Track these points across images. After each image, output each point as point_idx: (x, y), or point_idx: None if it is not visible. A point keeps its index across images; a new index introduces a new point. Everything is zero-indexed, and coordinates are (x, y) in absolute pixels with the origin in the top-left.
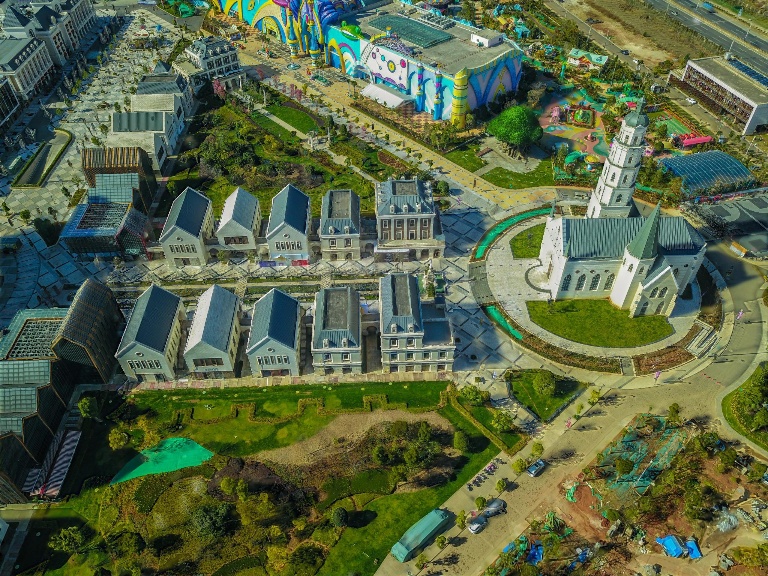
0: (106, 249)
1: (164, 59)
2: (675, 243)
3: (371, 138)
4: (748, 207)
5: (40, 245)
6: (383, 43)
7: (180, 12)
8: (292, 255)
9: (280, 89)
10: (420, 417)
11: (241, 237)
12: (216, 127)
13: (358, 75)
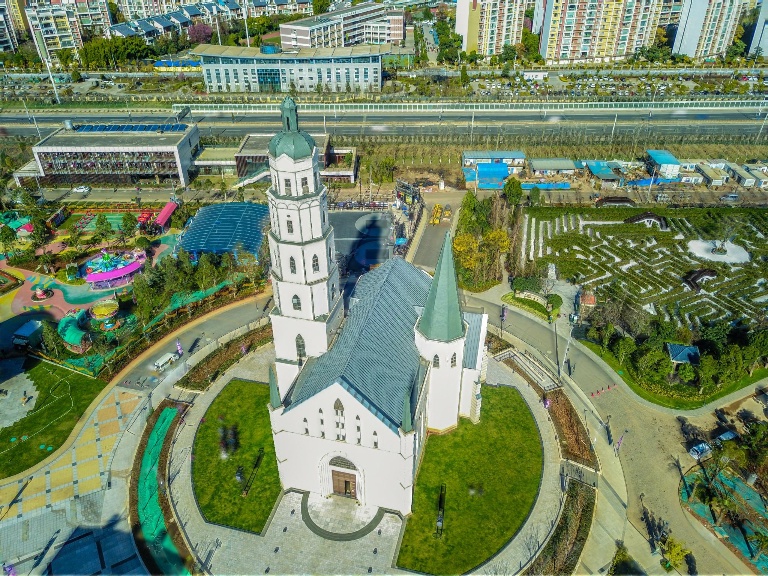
0: None
1: None
2: (424, 291)
3: None
4: None
5: None
6: None
7: None
8: None
9: None
10: None
11: None
12: None
13: None
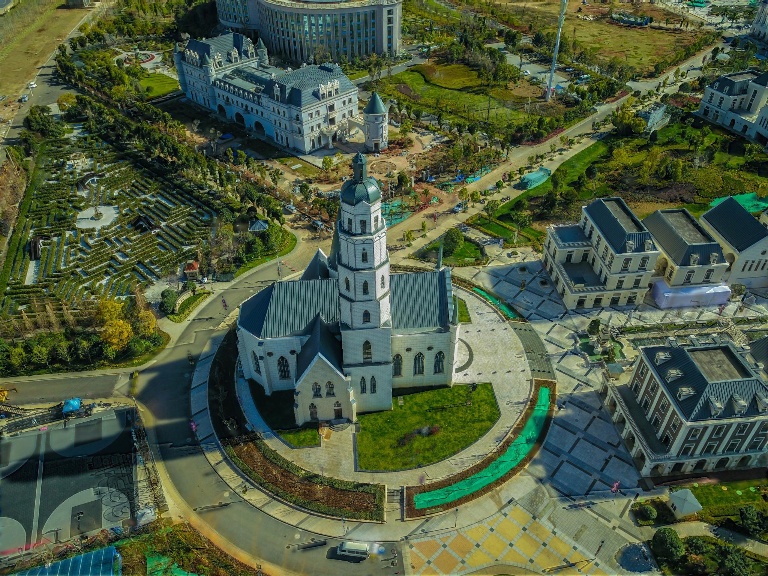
0: None
1: None
2: None
3: None
4: (18, 533)
5: None
6: None
7: None
8: None
9: None
10: None
11: None
12: None
13: None
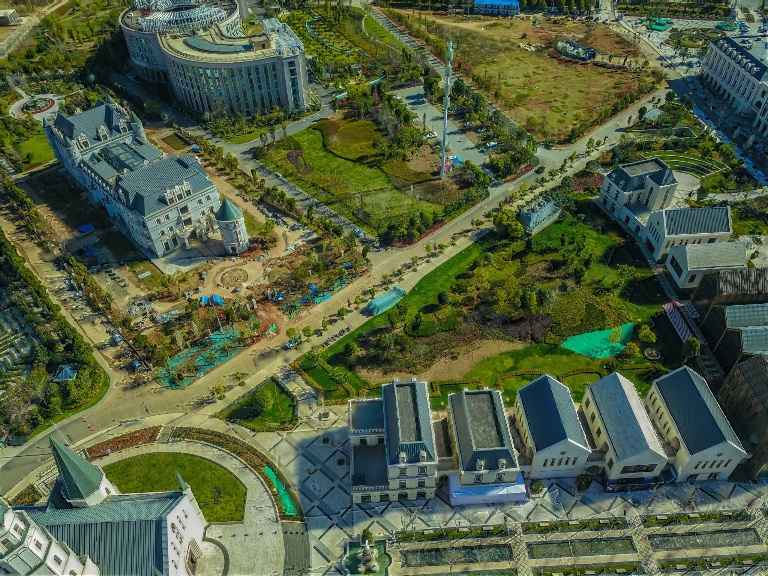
0: None
1: None
2: None
3: None
4: None
5: None
6: None
7: None
8: None
9: None
10: (386, 379)
11: None
12: None
13: None
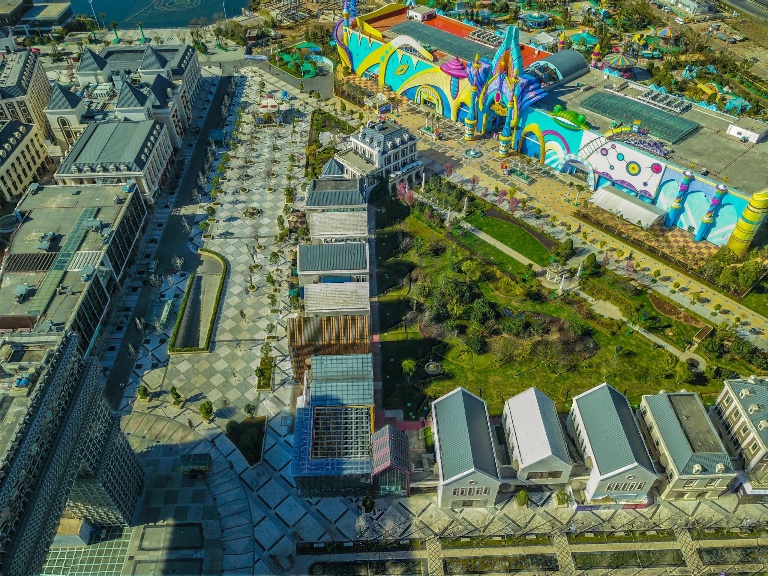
0: (351, 485)
1: (305, 140)
2: None
3: (627, 271)
4: None
5: (237, 461)
6: (622, 138)
7: (302, 72)
8: (624, 495)
9: (471, 188)
10: None
11: (553, 472)
12: (413, 249)
13: (566, 169)
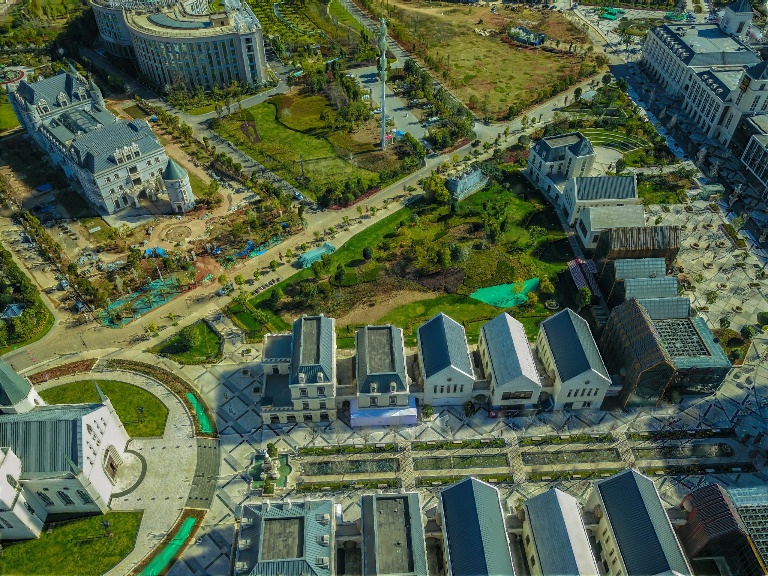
0: None
1: None
2: None
3: None
4: None
5: None
6: None
7: None
8: None
9: None
10: None
11: None
12: None
13: None
